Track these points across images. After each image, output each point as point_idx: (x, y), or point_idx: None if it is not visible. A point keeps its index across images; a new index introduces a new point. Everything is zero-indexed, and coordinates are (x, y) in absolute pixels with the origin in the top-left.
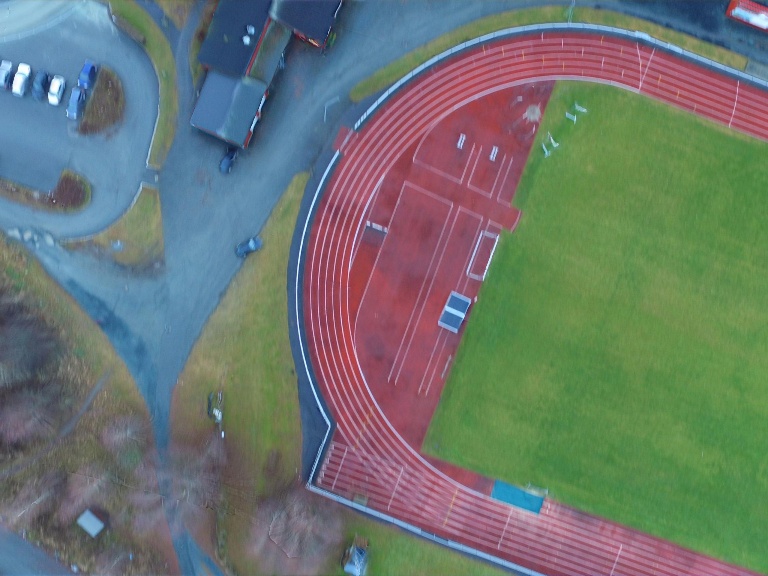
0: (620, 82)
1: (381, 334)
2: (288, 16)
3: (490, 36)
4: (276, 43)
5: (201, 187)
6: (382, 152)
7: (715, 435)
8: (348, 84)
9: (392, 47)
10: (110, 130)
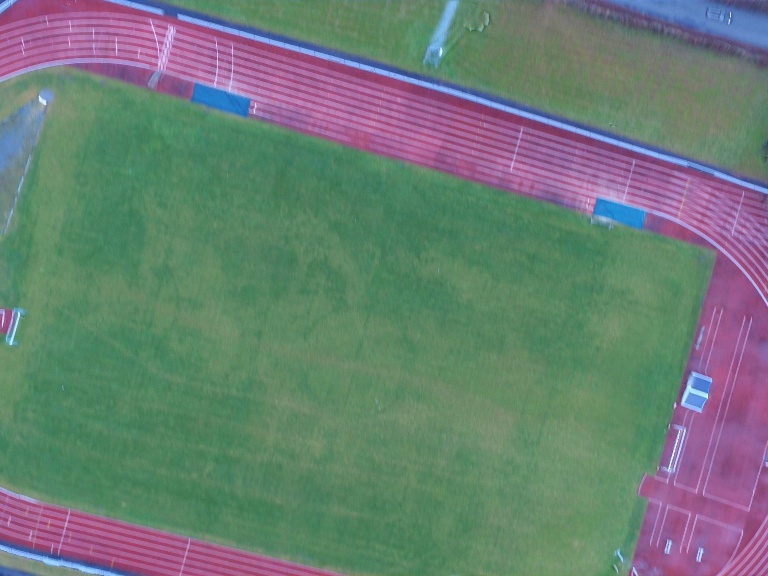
0: None
1: (763, 363)
2: None
3: None
4: None
5: None
6: None
7: (428, 292)
8: None
9: None
10: None
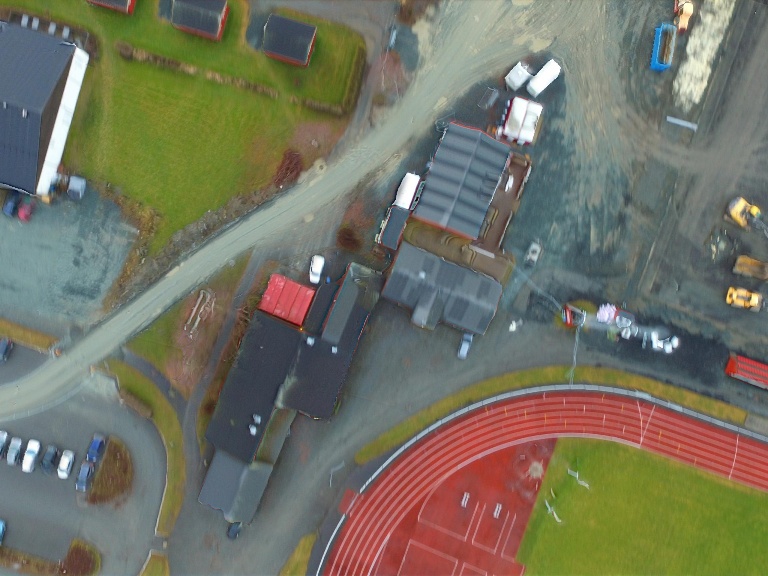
0: (621, 438)
1: None
2: (294, 402)
3: (493, 400)
4: (282, 422)
5: (209, 551)
6: (387, 512)
7: None
8: (353, 448)
9: (396, 410)
10: (119, 499)
